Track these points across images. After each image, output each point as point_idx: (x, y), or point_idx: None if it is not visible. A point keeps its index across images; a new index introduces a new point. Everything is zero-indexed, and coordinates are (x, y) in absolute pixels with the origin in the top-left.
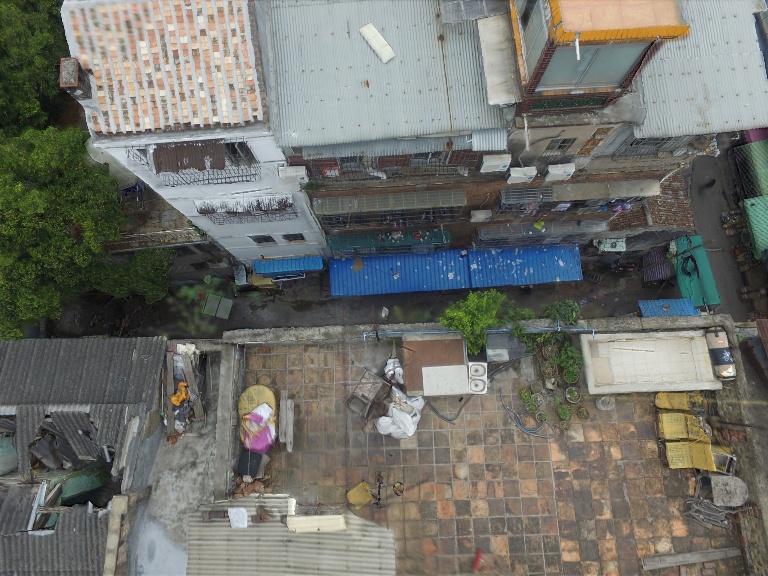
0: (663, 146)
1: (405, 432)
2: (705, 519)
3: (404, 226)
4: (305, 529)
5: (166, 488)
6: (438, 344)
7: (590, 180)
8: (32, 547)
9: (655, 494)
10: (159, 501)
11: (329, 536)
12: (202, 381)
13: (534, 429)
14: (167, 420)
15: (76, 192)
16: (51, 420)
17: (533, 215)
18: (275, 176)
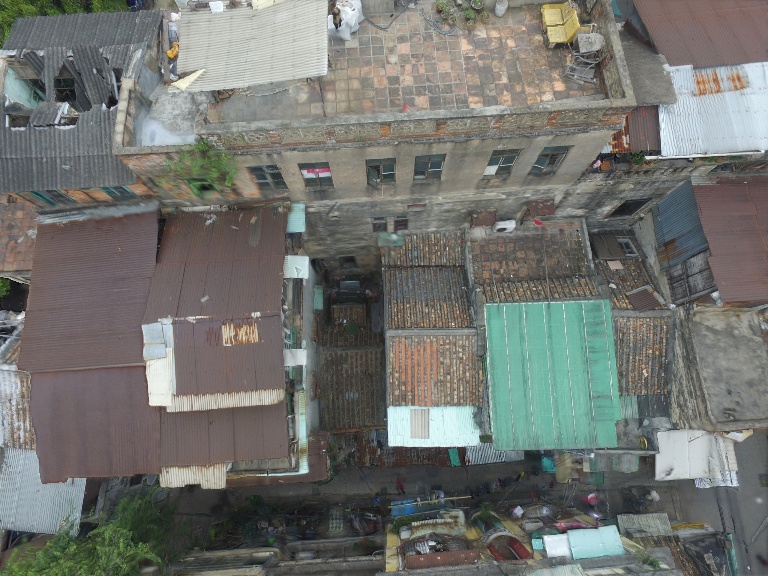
0: None
1: (347, 22)
2: (578, 77)
3: None
4: (265, 4)
5: (164, 103)
6: None
7: None
8: (58, 138)
9: (541, 67)
10: (158, 110)
11: (282, 5)
12: None
13: (448, 31)
14: (164, 70)
15: None
16: (72, 58)
17: None
18: None
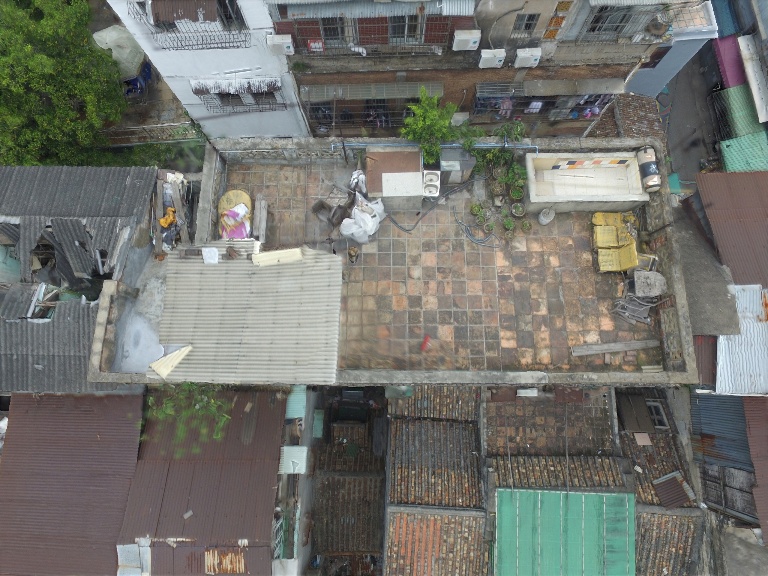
0: (622, 31)
1: (365, 231)
2: (630, 315)
3: (387, 126)
4: (267, 262)
5: (152, 291)
6: (398, 155)
7: (559, 77)
8: (31, 333)
9: (587, 296)
10: (145, 301)
11: (287, 266)
12: (189, 219)
13: (482, 239)
14: (156, 240)
15: (81, 66)
16: (51, 229)
17: (508, 118)
18: (264, 50)
